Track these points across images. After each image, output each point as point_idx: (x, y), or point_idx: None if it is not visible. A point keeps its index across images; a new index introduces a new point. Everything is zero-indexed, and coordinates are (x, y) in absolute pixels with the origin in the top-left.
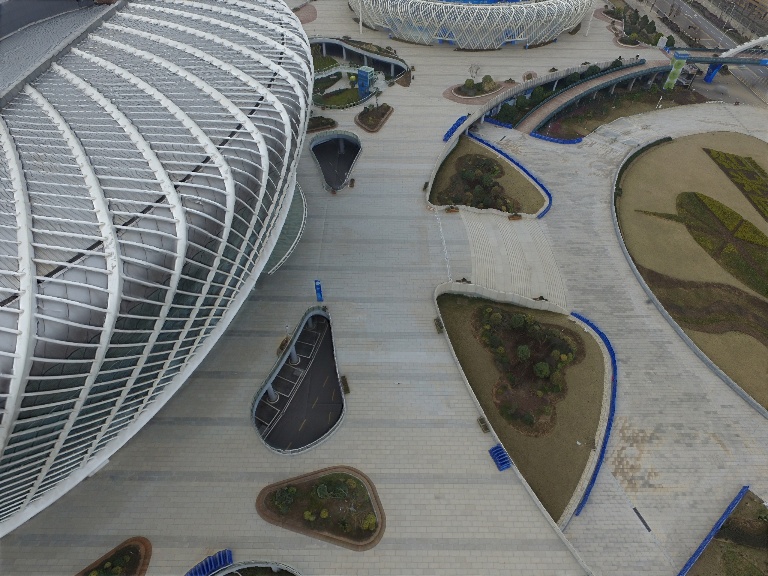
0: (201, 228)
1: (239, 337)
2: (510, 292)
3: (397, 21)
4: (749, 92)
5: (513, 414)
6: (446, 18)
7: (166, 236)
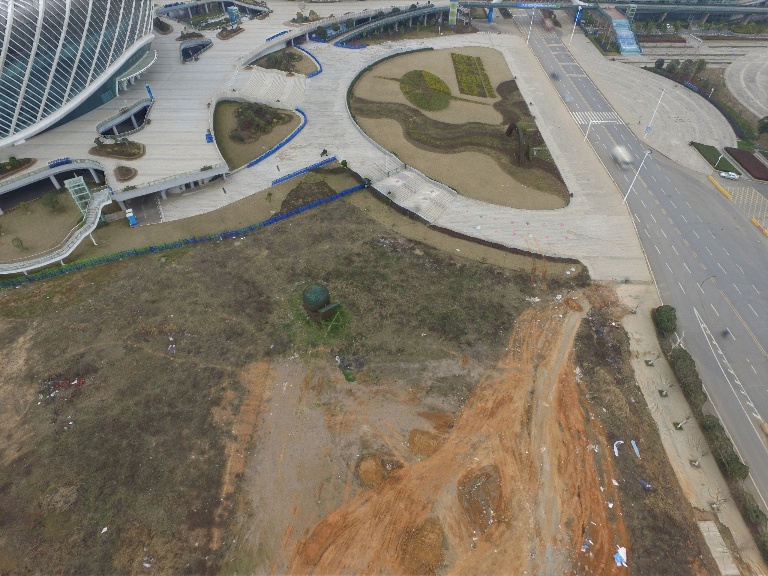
0: (52, 5)
1: (103, 110)
2: None
3: None
4: (515, 27)
5: (234, 136)
6: None
7: (34, 1)
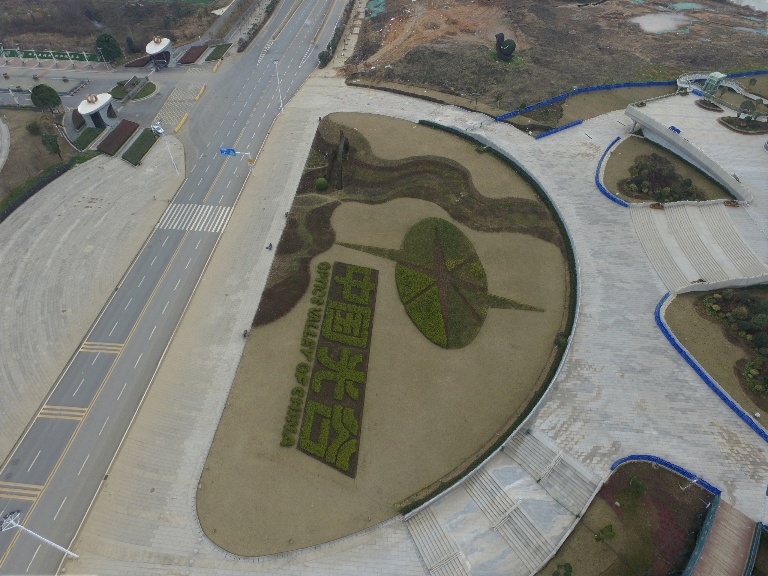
0: None
1: None
2: None
3: None
4: None
5: None
6: None
7: None
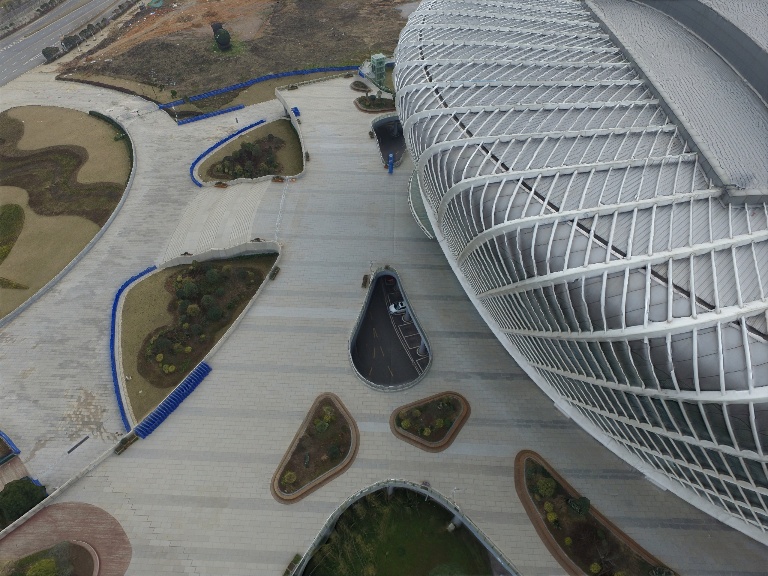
0: None
1: None
2: None
3: None
4: None
5: None
6: None
7: None
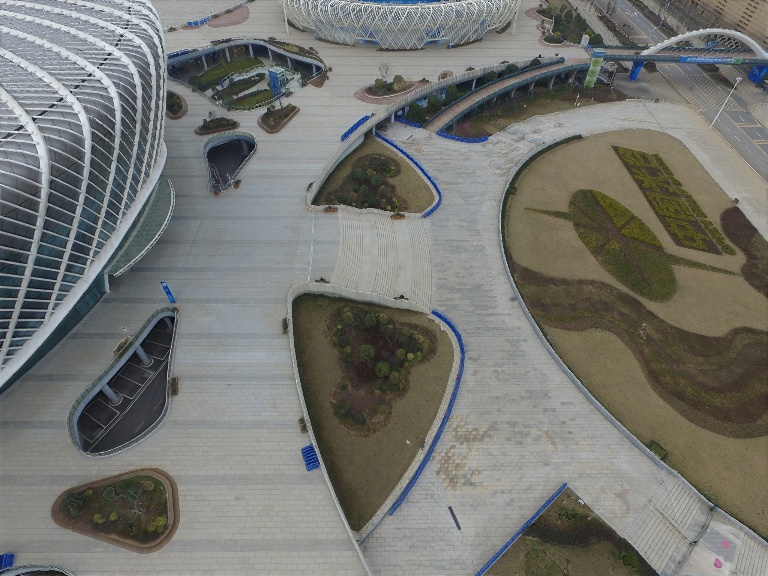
0: None
1: (81, 340)
2: (369, 291)
3: (319, 22)
4: (672, 89)
5: (345, 414)
6: (364, 18)
7: None
